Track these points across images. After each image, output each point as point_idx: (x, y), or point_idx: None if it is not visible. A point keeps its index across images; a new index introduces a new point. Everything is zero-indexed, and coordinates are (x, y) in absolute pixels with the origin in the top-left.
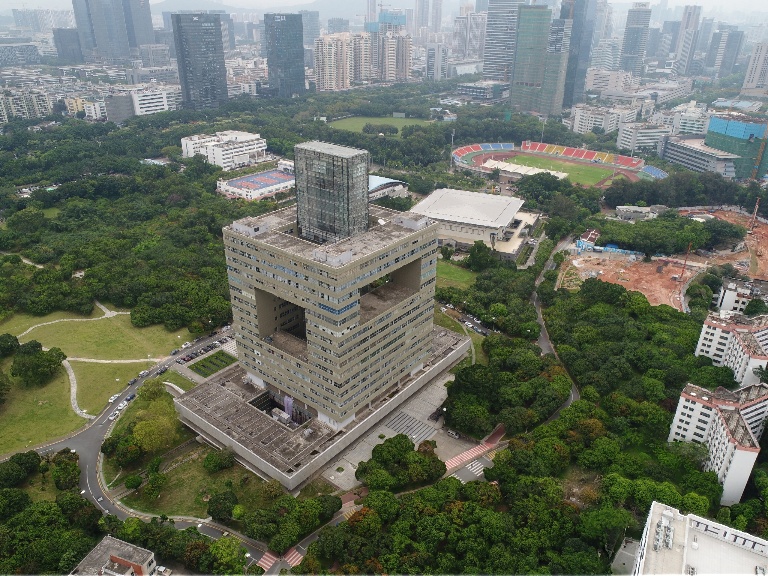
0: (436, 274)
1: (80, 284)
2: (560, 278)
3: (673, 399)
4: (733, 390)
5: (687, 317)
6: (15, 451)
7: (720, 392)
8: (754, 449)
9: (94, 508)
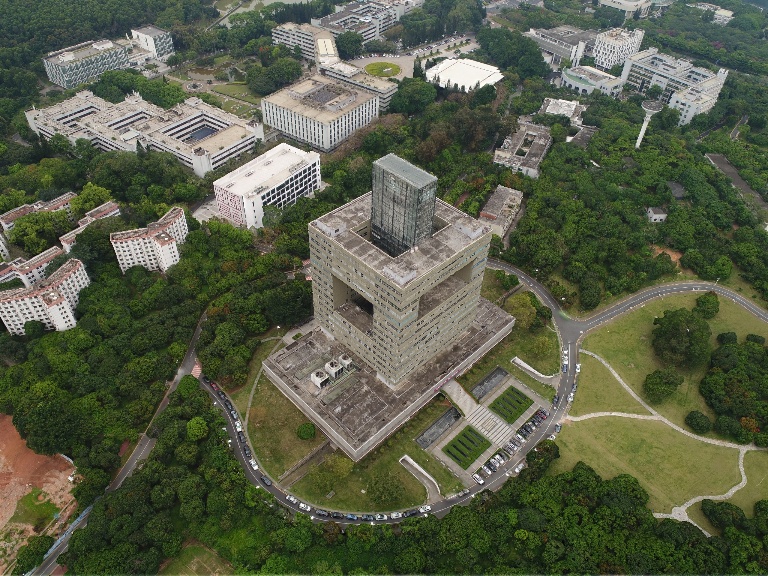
0: None
1: (763, 555)
2: (6, 575)
3: (153, 280)
4: (98, 283)
5: (7, 378)
6: (611, 323)
7: (153, 232)
8: None
9: (521, 252)
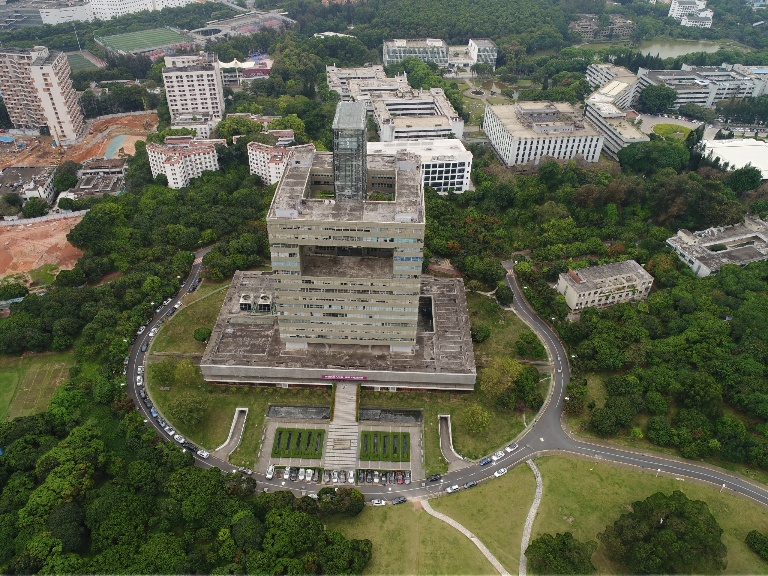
0: (2, 406)
1: None
2: None
3: None
4: None
5: None
6: (607, 465)
7: None
8: (313, 145)
9: (574, 328)
